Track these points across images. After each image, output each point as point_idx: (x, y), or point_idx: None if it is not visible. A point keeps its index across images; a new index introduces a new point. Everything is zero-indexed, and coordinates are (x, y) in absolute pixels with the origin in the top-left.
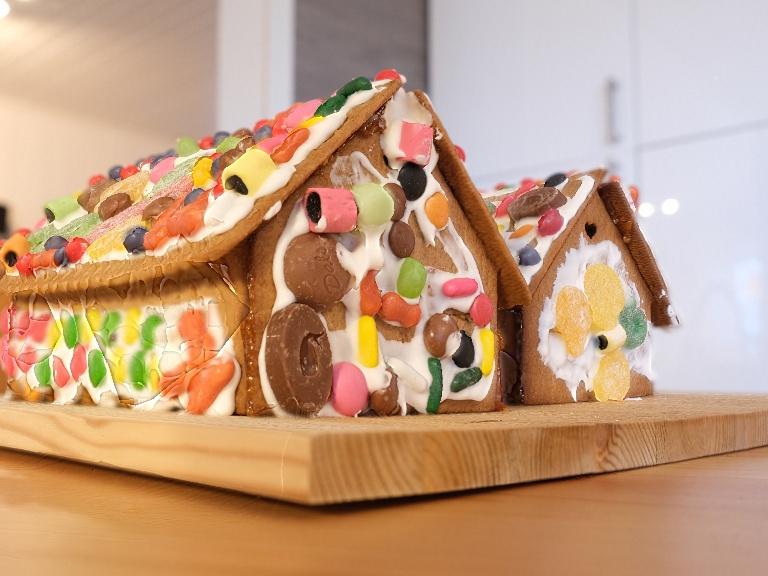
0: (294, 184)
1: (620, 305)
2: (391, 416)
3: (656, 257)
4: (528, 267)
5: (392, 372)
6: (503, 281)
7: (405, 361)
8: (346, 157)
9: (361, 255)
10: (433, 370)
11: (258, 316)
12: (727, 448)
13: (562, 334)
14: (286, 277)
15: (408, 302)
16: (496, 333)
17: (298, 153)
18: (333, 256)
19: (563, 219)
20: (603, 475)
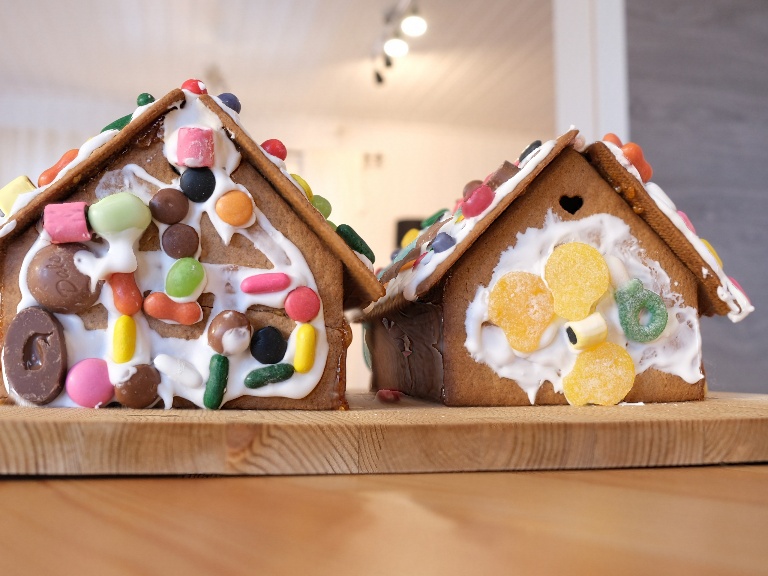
0: (33, 203)
1: (595, 290)
2: (144, 409)
3: (681, 227)
4: (436, 255)
5: (153, 368)
6: (352, 273)
7: (187, 357)
8: (117, 171)
9: (102, 260)
10: (212, 366)
11: (6, 319)
12: (542, 464)
13: (499, 327)
14: (29, 285)
15: (176, 301)
16: (336, 328)
17: (58, 175)
18: (69, 263)
19: (494, 197)
20: (234, 477)
